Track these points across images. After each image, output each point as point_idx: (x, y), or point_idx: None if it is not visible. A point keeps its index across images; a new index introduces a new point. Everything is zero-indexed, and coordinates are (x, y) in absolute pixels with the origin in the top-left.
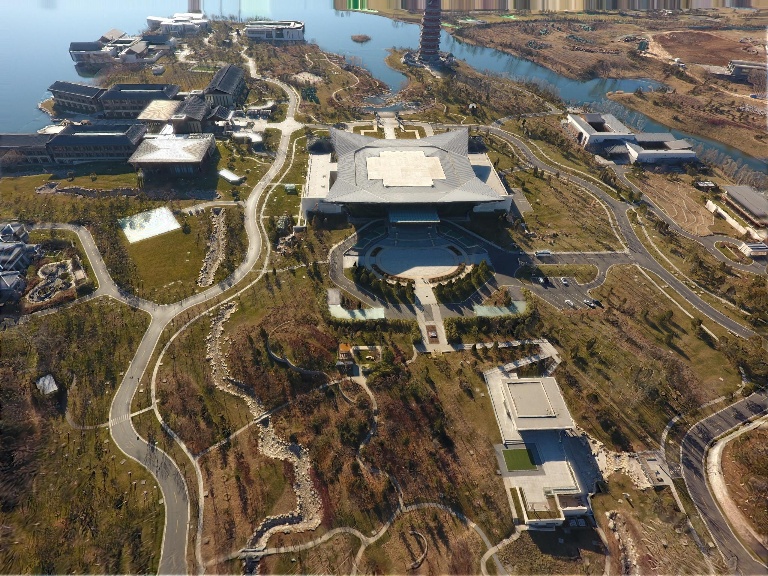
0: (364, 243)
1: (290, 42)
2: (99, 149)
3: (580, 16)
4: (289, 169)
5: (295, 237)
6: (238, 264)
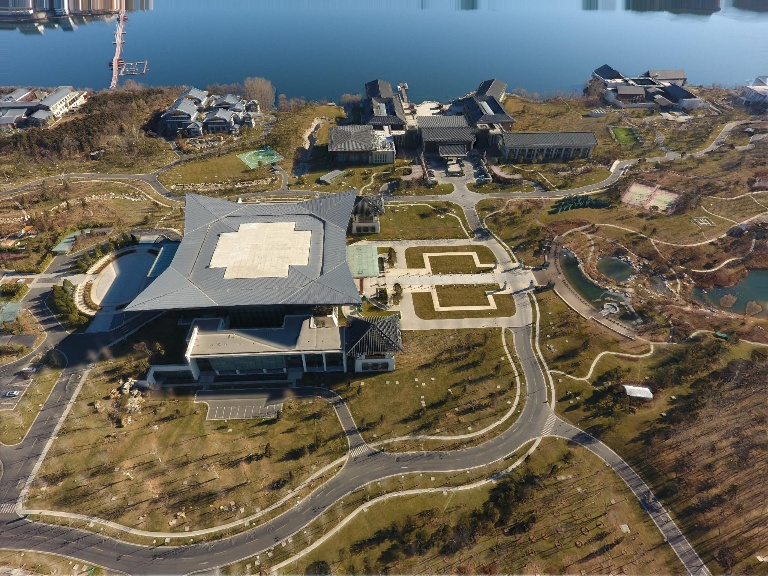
0: None
1: None
2: None
3: None
4: None
5: None
6: None
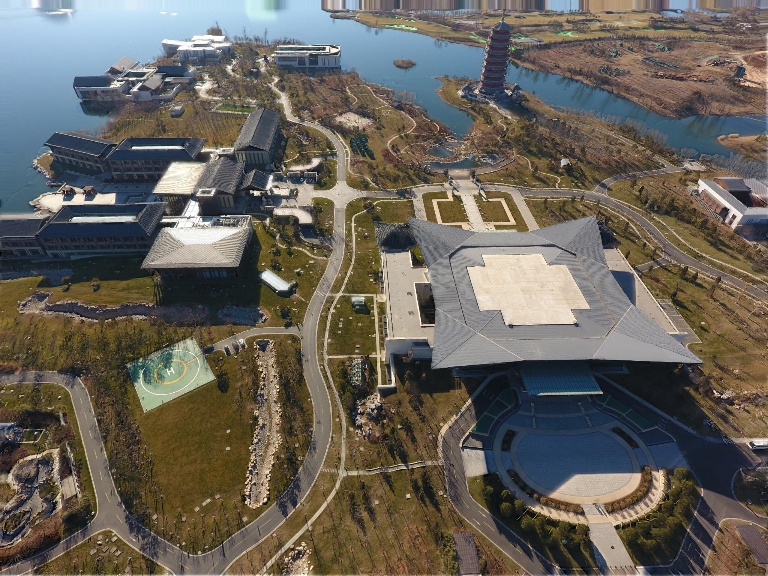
0: (488, 424)
1: (327, 71)
2: (104, 240)
3: (651, 33)
4: (352, 267)
5: (382, 406)
6: (302, 455)
